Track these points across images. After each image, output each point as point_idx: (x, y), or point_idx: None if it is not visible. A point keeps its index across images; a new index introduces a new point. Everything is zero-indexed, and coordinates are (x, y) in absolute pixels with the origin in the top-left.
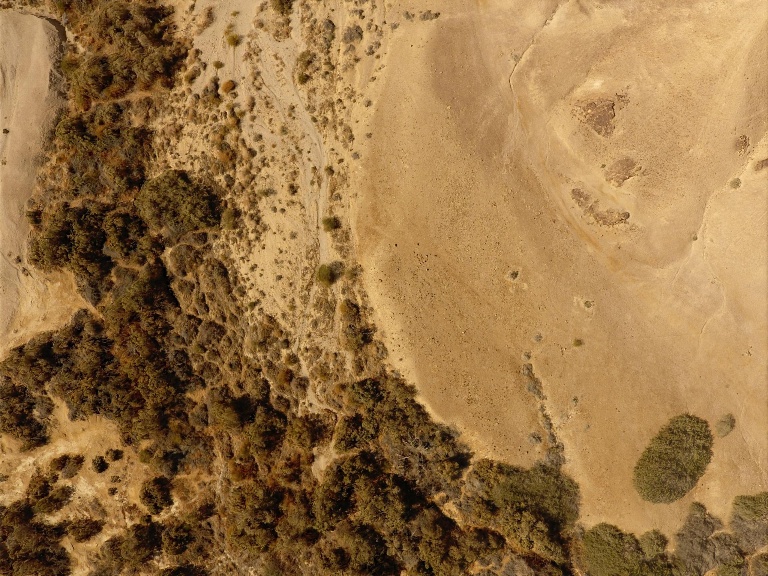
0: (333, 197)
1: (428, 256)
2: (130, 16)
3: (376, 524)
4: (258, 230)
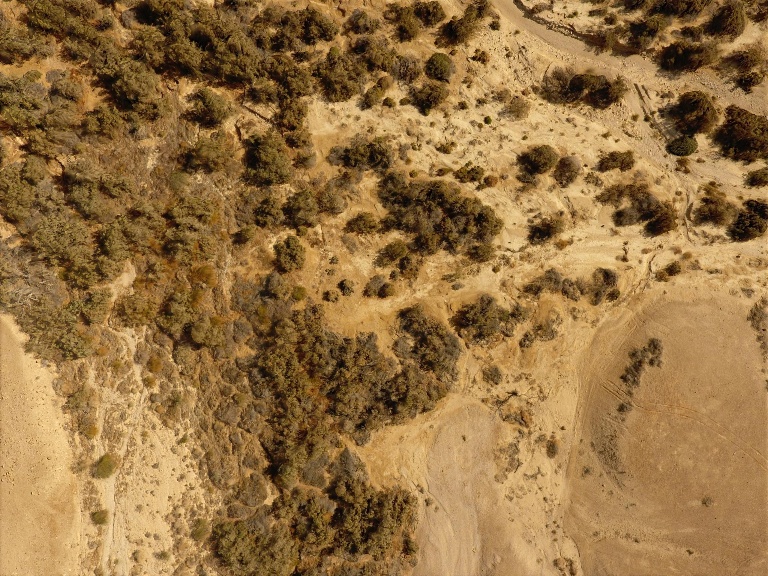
0: (95, 546)
1: (1, 480)
2: None
3: (75, 221)
4: (173, 517)
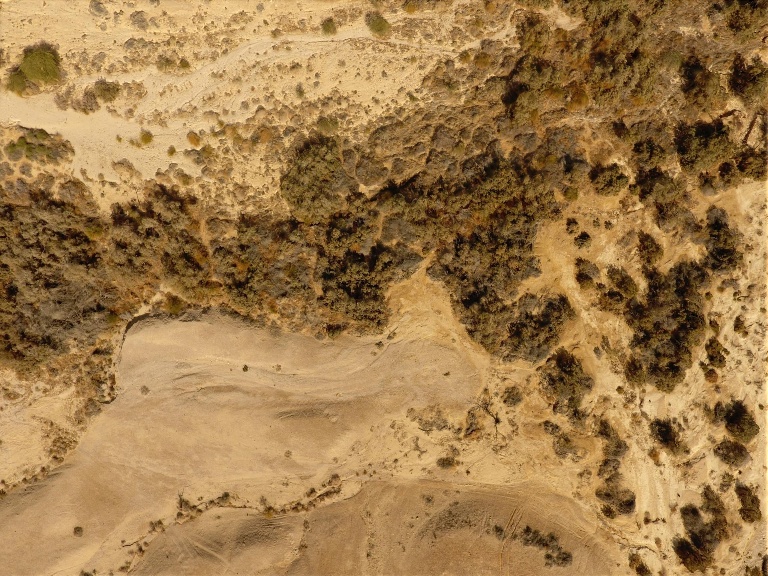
0: (302, 27)
1: None
2: (122, 242)
3: None
4: (338, 98)
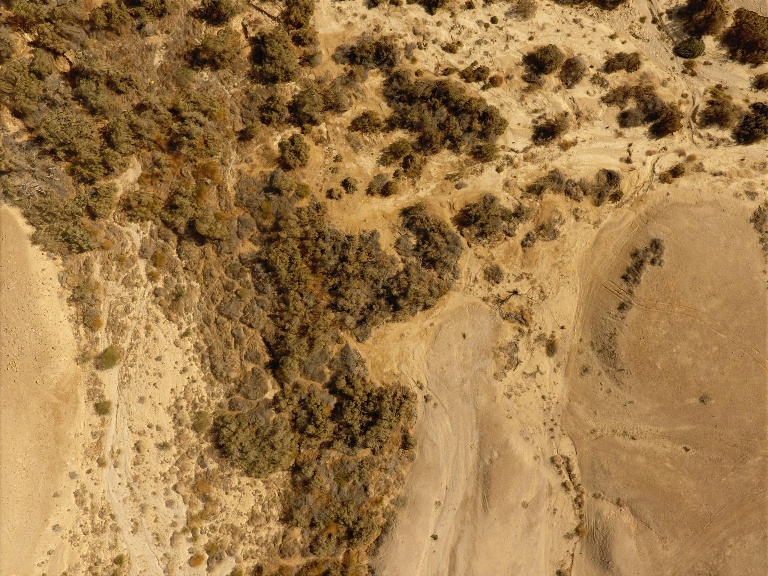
0: (98, 435)
1: (7, 369)
2: None
3: (82, 116)
4: (175, 409)
